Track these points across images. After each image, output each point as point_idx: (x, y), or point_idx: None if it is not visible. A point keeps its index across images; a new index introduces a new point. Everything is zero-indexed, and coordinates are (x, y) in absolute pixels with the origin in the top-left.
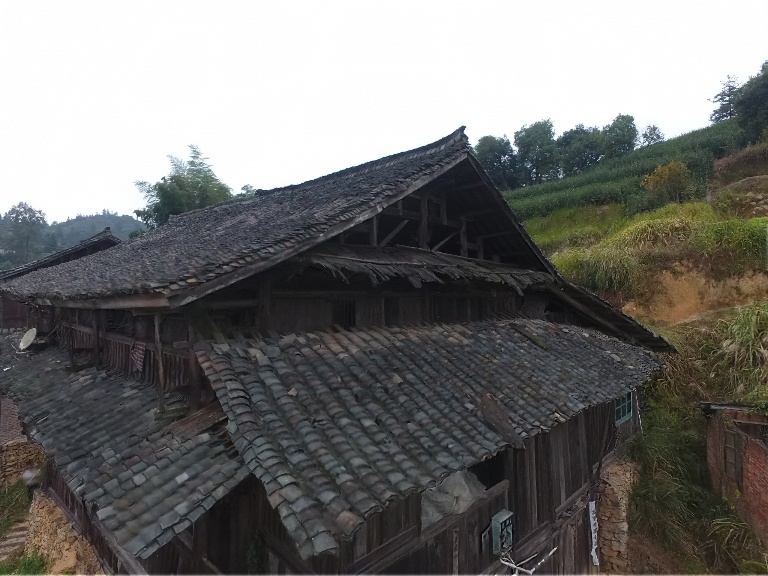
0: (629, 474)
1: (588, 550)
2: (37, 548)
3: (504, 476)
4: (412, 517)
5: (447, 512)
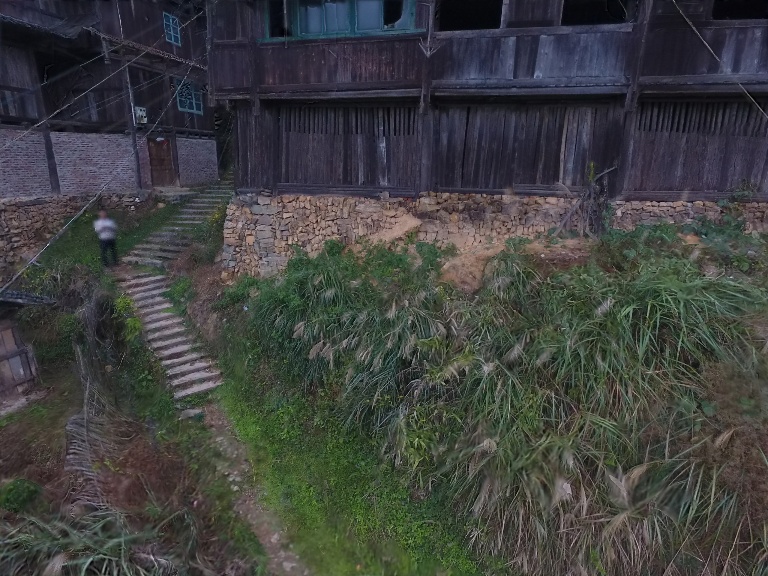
0: None
1: None
2: (301, 245)
3: None
4: None
5: None
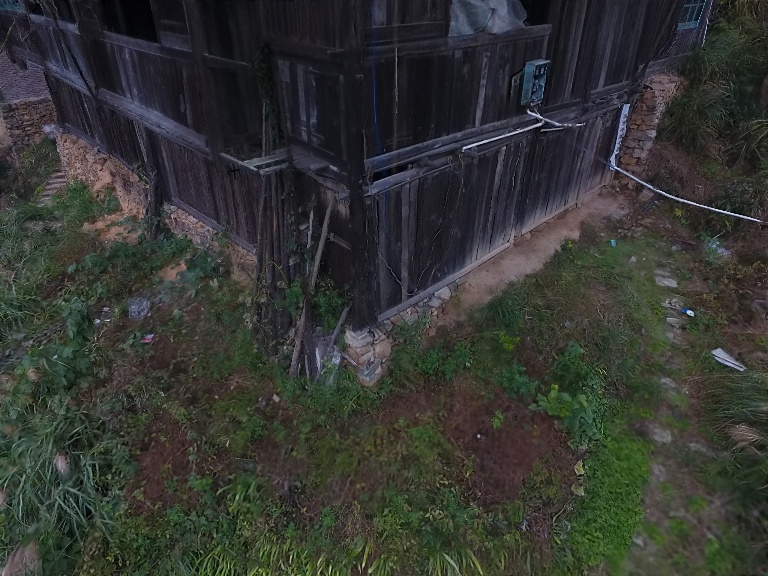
0: (674, 85)
1: (608, 155)
2: (76, 177)
3: (547, 20)
4: (440, 7)
5: (480, 25)
